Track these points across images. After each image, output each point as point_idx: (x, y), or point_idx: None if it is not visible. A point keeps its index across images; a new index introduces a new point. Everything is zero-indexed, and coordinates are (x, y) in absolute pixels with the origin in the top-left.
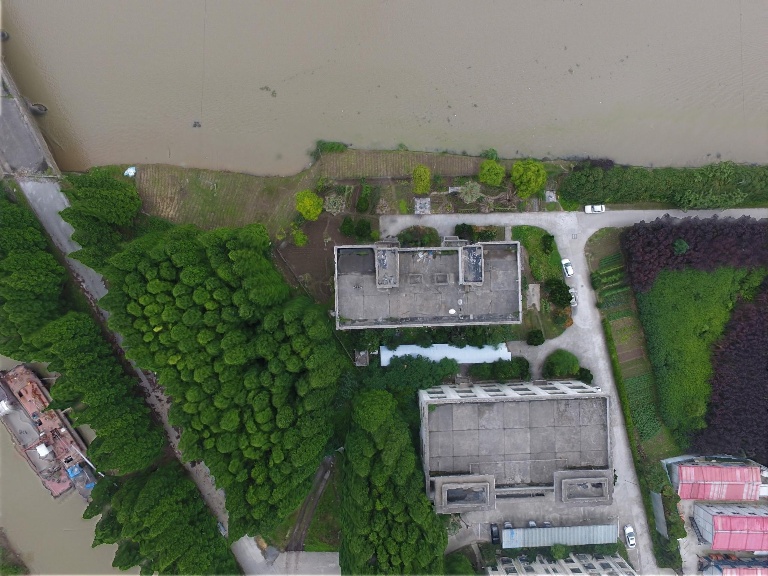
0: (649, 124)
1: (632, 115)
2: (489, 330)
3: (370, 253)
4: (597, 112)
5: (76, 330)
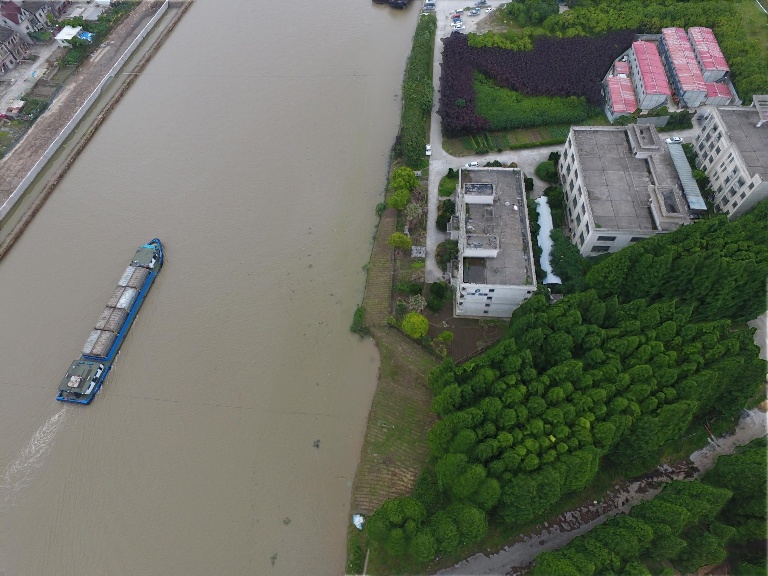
0: (370, 125)
1: (363, 133)
2: None
3: (467, 260)
4: (357, 150)
5: None
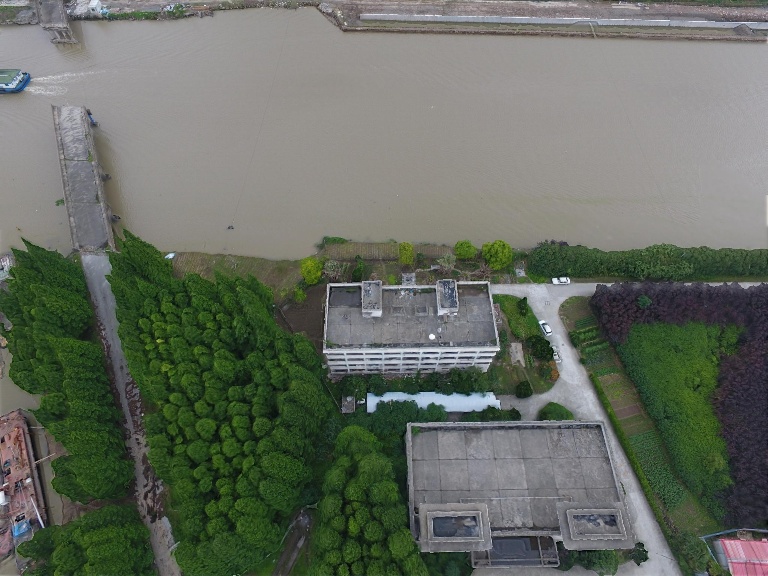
0: (595, 226)
1: (579, 220)
2: (474, 374)
3: (358, 290)
4: (550, 218)
5: (86, 351)
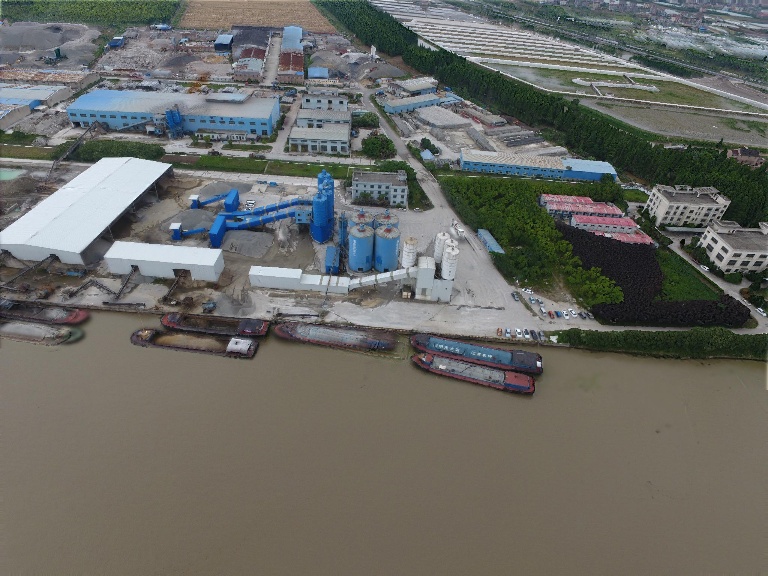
0: (762, 381)
1: None
2: None
3: None
4: None
5: None
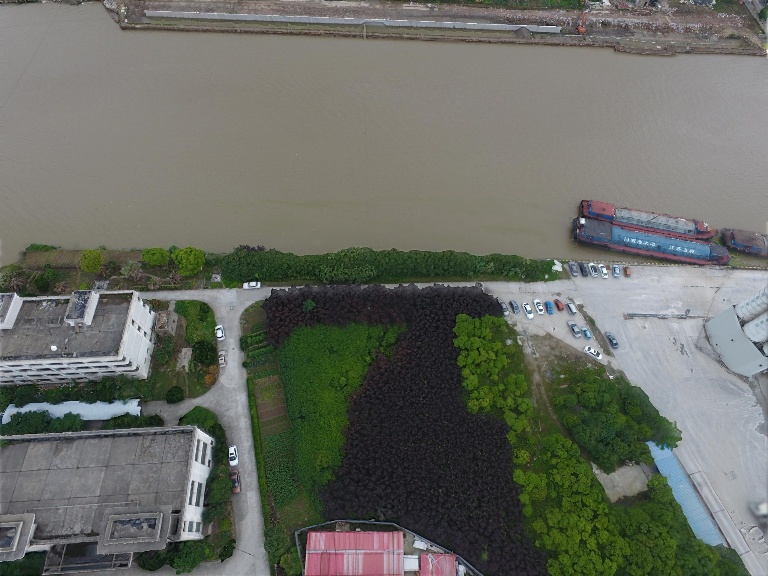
0: (312, 229)
1: (297, 223)
2: (118, 382)
3: None
4: (269, 222)
5: None
